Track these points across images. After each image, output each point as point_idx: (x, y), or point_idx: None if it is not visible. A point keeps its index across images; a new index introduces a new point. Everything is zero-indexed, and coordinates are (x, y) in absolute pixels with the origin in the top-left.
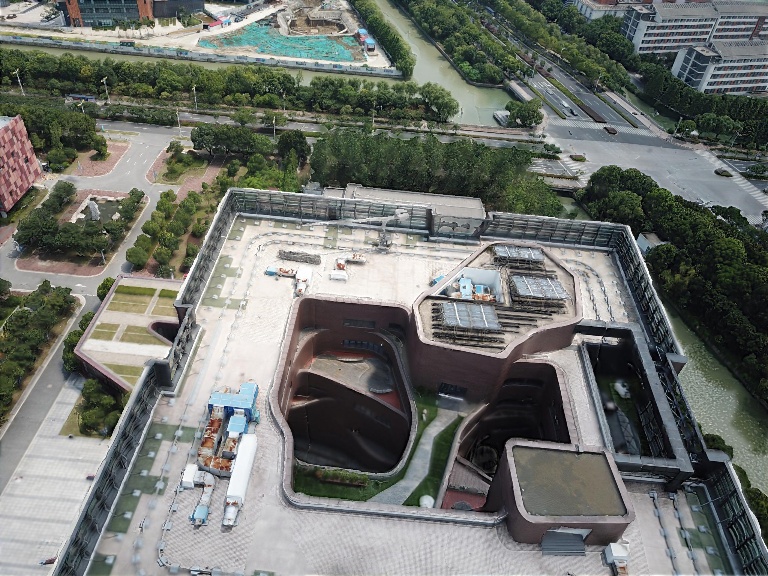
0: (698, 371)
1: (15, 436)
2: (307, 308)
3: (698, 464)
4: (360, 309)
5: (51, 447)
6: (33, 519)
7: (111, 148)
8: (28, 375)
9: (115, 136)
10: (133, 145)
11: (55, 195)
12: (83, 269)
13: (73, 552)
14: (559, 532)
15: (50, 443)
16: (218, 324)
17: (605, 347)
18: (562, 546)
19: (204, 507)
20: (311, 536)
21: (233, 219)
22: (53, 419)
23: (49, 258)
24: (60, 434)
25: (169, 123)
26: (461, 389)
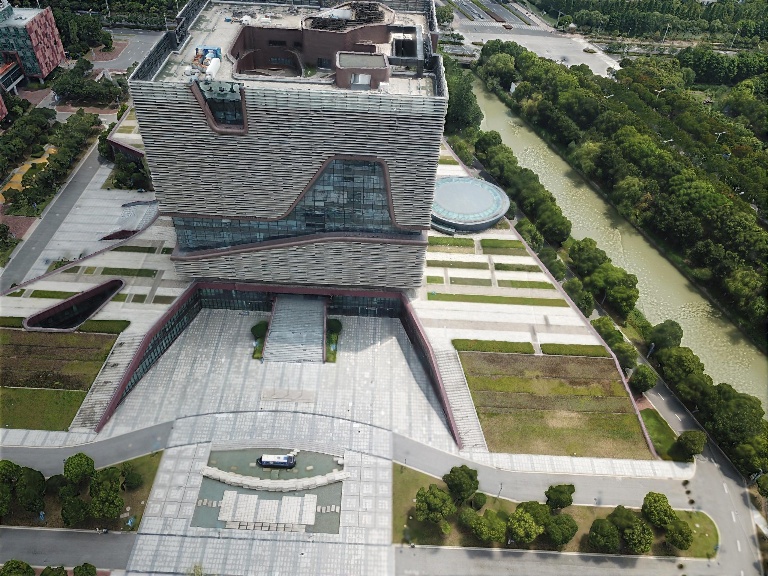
0: (541, 160)
1: (72, 190)
2: (248, 33)
3: (430, 62)
4: (277, 32)
5: (96, 194)
6: (91, 224)
7: (115, 44)
8: (75, 162)
9: (117, 37)
10: (132, 43)
11: (78, 67)
12: (104, 110)
13: (140, 75)
14: (359, 84)
15: (95, 192)
16: (199, 35)
17: (405, 41)
18: (360, 88)
19: None
20: None
21: (206, 2)
22: (95, 182)
23: (79, 105)
24: (101, 188)
25: (158, 28)
26: (328, 61)
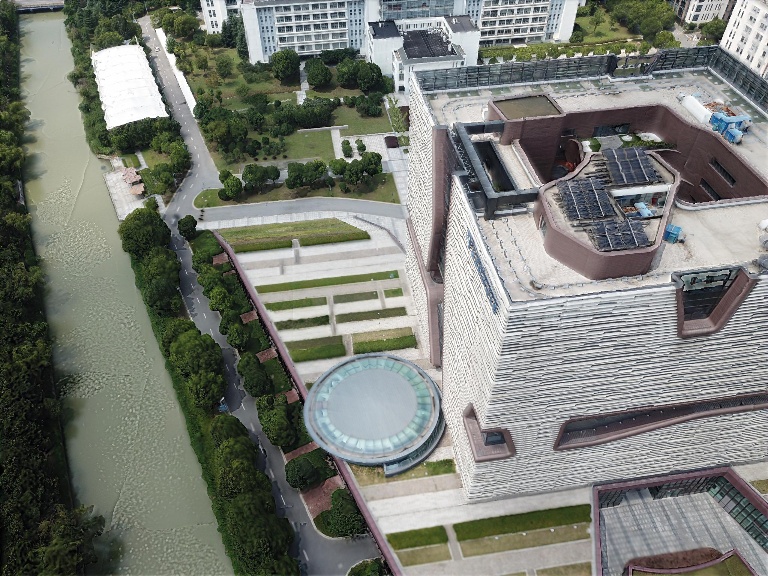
0: None
1: None
2: None
3: None
4: None
5: None
6: None
7: None
8: None
9: None
10: None
11: None
12: None
13: None
14: None
15: None
16: None
17: None
18: None
19: (697, 96)
20: (638, 102)
21: None
22: None
23: None
24: None
25: None
26: None
